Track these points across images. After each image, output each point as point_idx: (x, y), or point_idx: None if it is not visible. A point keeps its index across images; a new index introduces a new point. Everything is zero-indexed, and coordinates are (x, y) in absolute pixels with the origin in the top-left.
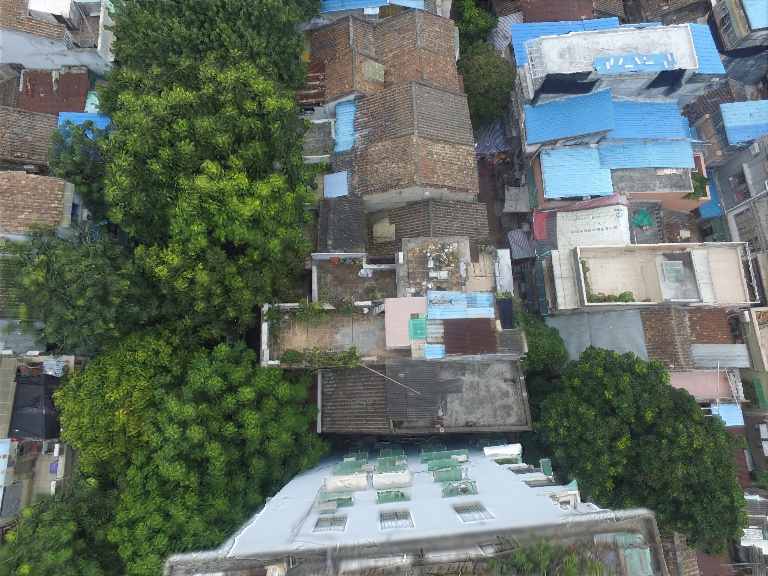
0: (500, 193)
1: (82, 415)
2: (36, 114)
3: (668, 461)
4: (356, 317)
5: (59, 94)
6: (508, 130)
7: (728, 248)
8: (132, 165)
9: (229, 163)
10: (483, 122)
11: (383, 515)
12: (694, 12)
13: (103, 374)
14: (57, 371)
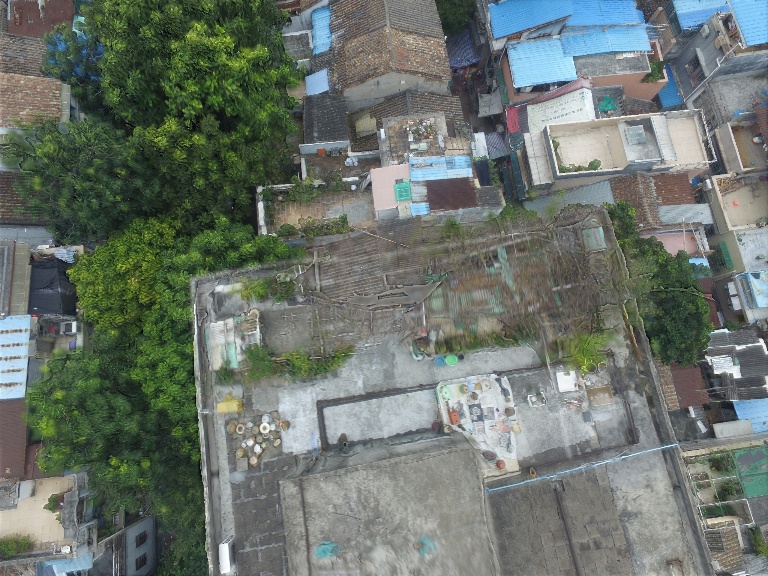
0: (474, 106)
1: (97, 283)
2: (26, 38)
3: None
4: (345, 195)
5: (46, 20)
6: (477, 39)
7: (686, 118)
8: (126, 33)
9: (216, 32)
10: (452, 33)
11: (380, 295)
12: None
13: (112, 253)
14: (68, 259)
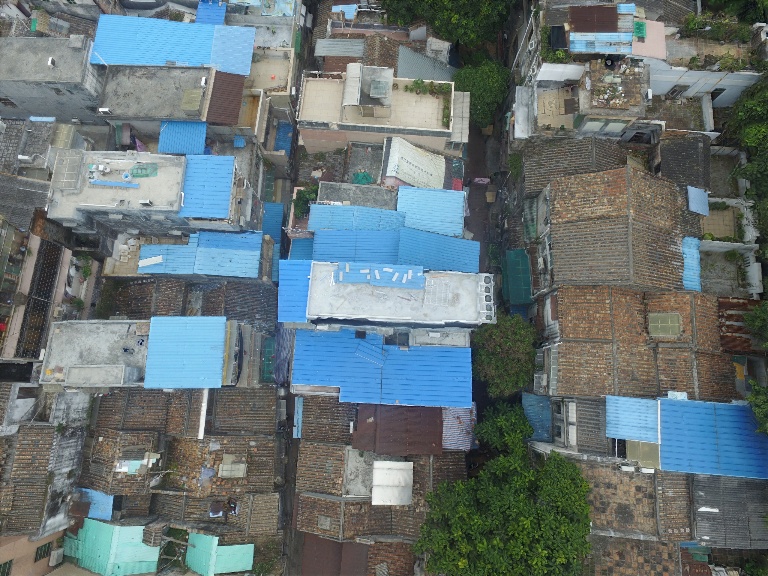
0: None
1: None
2: None
3: None
4: None
5: None
6: None
7: None
8: None
9: None
10: None
11: None
12: (222, 431)
13: None
14: None
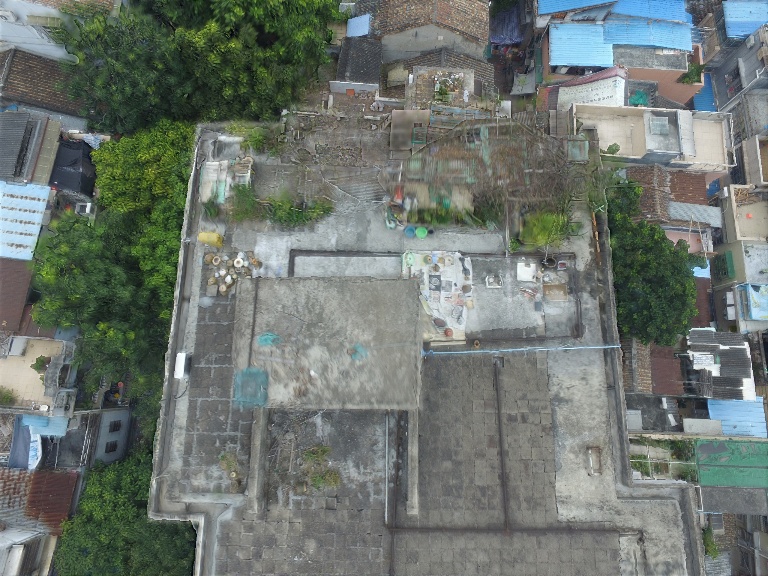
0: (510, 86)
1: (116, 166)
2: None
3: (631, 251)
4: (365, 133)
5: None
6: (523, 18)
7: (714, 122)
8: None
9: None
10: (500, 8)
11: None
12: None
13: (136, 145)
14: (94, 146)
